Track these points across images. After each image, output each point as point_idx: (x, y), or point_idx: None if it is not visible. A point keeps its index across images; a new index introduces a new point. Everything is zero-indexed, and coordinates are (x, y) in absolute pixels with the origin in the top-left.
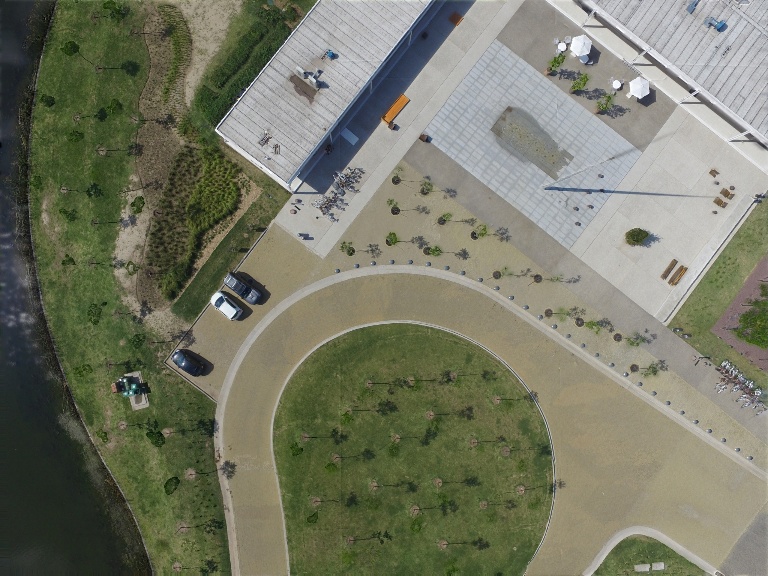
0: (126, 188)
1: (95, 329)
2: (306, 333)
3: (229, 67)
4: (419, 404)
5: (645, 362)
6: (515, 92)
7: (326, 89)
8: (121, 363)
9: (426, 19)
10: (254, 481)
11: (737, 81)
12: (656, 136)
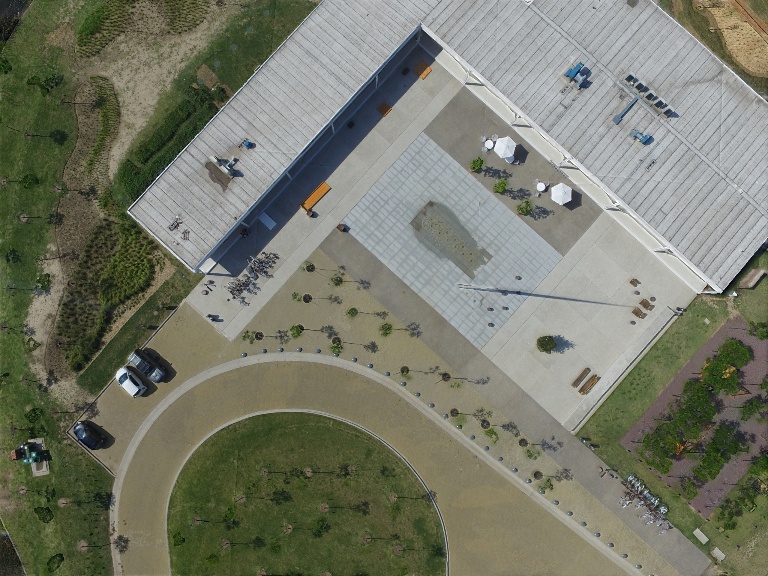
0: (43, 256)
1: (4, 392)
2: (208, 414)
3: (153, 144)
4: (315, 496)
5: (550, 470)
6: (438, 187)
7: (240, 178)
8: (26, 428)
9: (353, 108)
10: (146, 558)
11: (659, 196)
12: (578, 241)
